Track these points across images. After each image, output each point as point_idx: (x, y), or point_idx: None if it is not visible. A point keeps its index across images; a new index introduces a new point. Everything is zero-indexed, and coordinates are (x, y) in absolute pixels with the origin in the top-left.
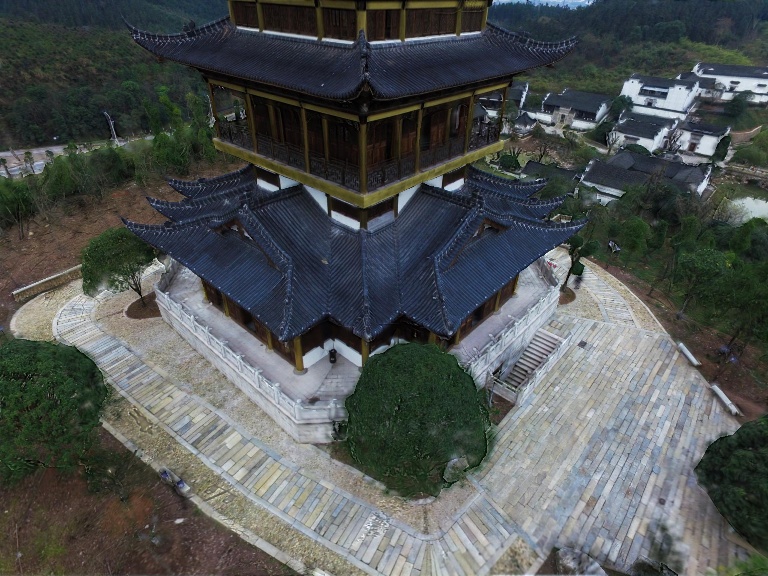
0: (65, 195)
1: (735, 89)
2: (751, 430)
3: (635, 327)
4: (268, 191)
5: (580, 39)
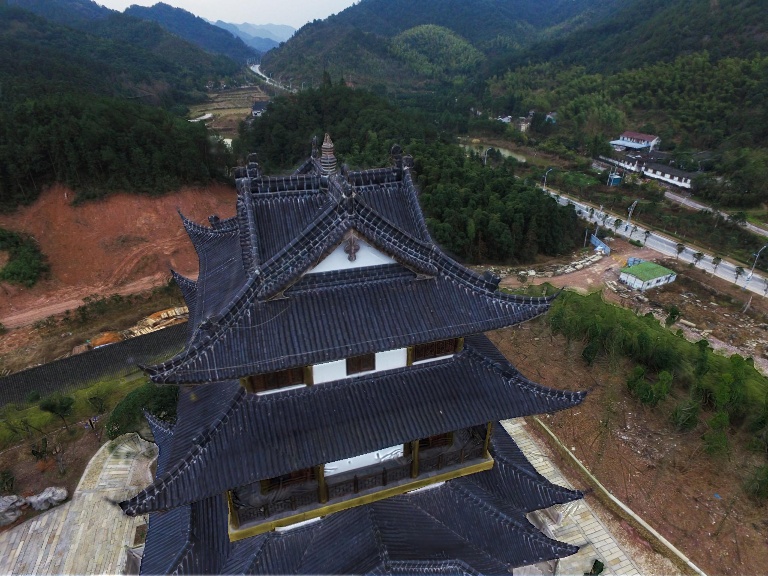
0: (632, 356)
1: None
2: None
3: None
4: None
5: None
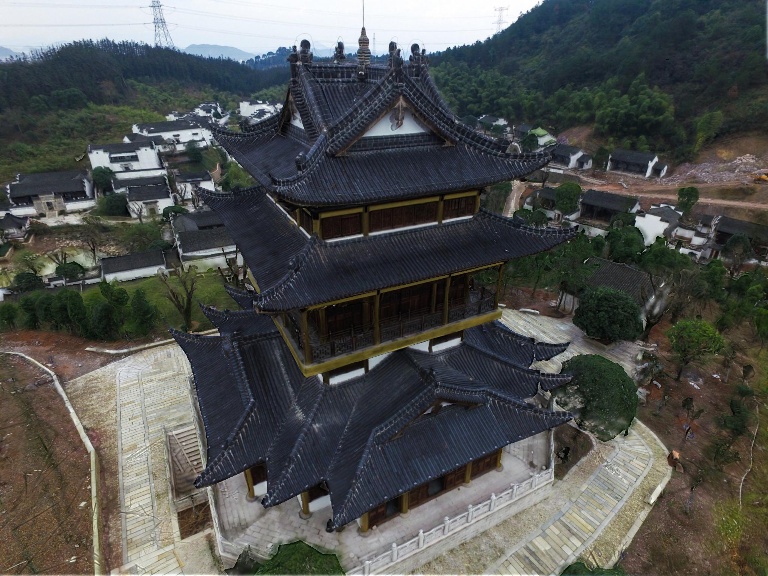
0: None
1: (180, 141)
2: (593, 305)
3: None
4: (349, 381)
5: None
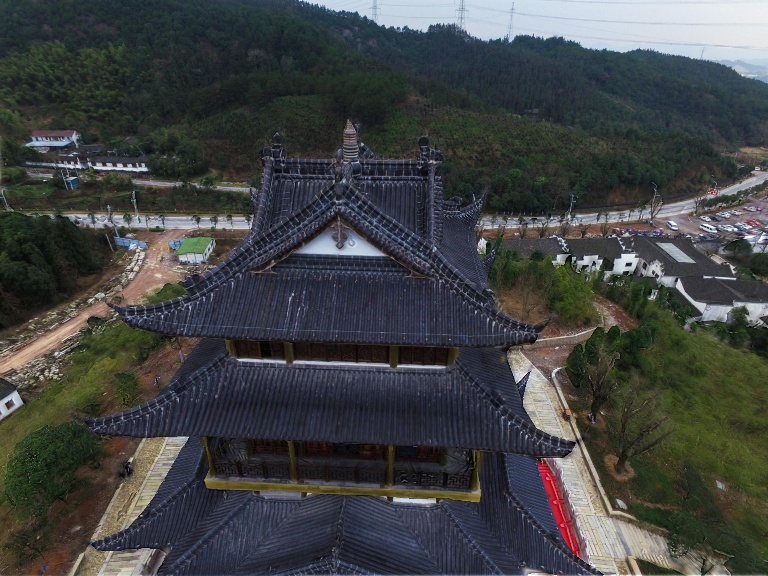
0: None
1: None
2: None
3: None
4: None
5: None
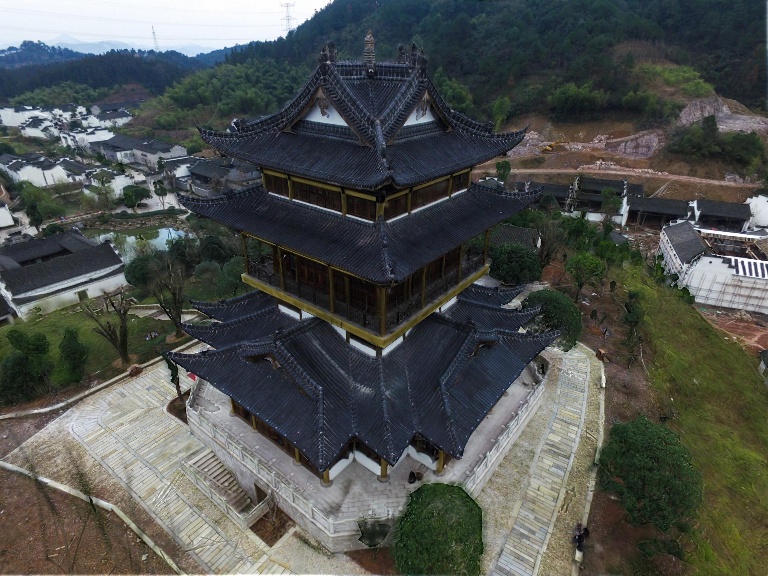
0: None
1: None
2: None
3: None
4: (394, 349)
5: None
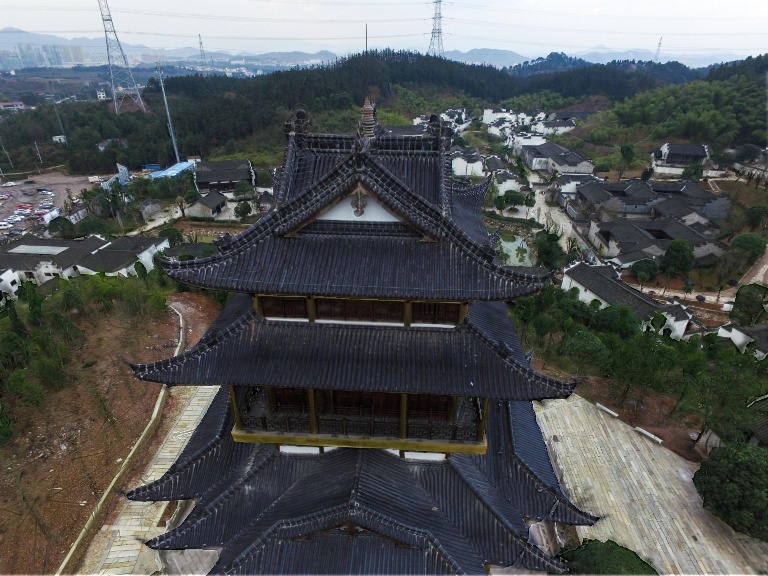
0: None
1: None
2: (723, 469)
3: (564, 403)
4: (300, 454)
5: (273, 112)
